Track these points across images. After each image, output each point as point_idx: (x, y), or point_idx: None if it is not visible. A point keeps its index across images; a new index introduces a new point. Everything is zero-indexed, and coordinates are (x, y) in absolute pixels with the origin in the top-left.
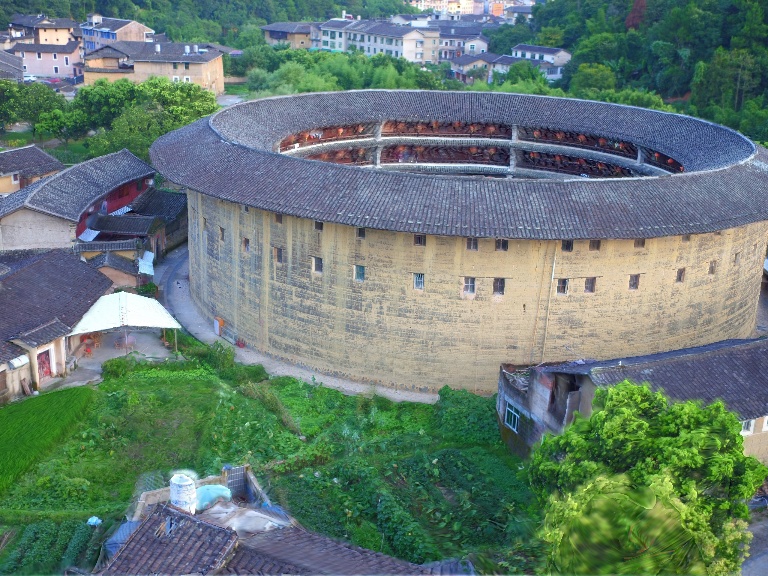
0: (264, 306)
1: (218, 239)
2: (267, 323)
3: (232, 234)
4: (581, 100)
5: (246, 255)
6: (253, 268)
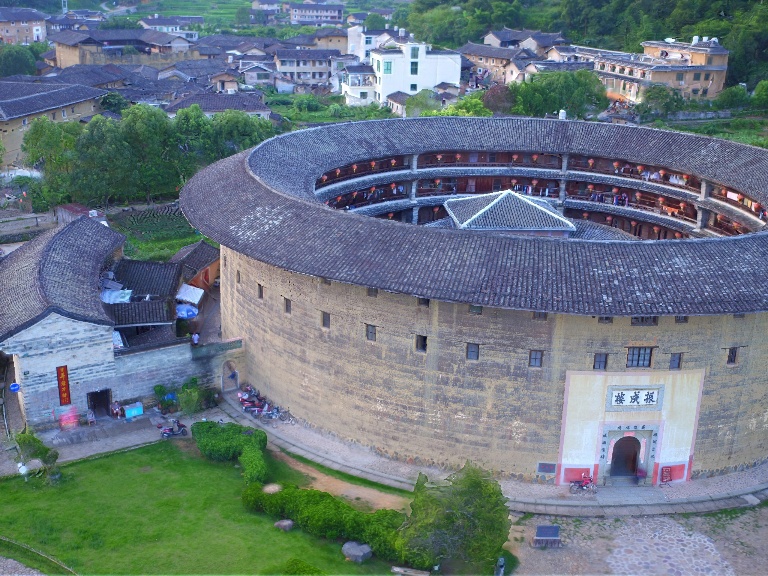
0: None
1: None
2: None
3: None
4: None
5: None
6: None
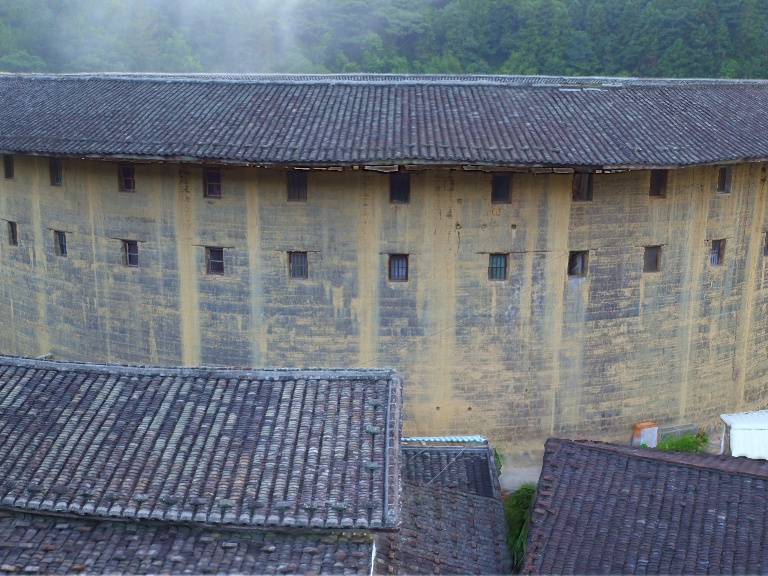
0: (743, 342)
1: (640, 273)
2: (745, 368)
3: (688, 246)
4: (208, 74)
5: (718, 270)
6: (730, 287)
